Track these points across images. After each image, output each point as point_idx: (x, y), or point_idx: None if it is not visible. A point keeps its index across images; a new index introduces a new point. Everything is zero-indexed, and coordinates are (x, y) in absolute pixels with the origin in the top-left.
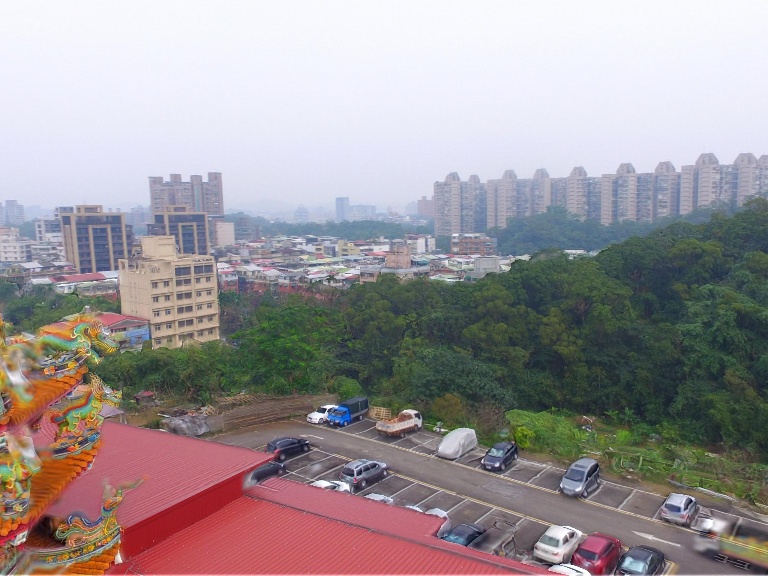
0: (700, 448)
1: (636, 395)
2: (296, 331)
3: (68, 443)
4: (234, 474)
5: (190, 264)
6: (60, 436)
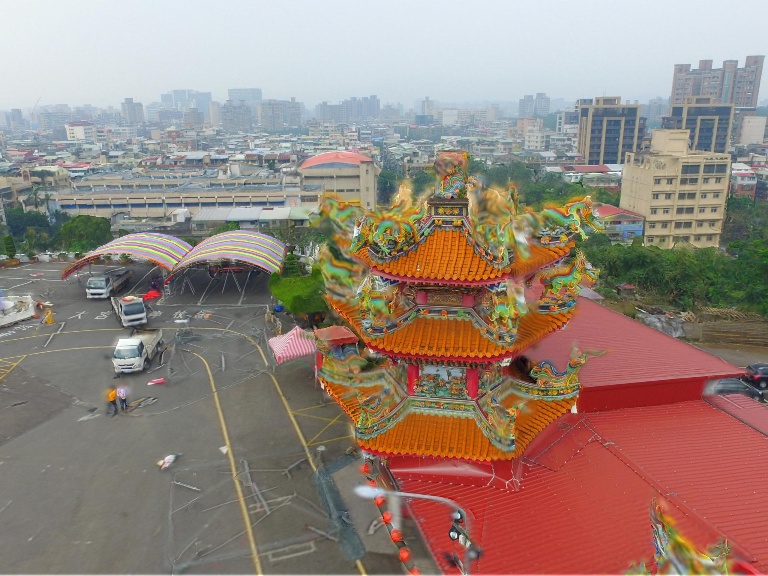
0: None
1: None
2: None
3: (550, 303)
4: (696, 376)
5: (700, 162)
6: (545, 296)
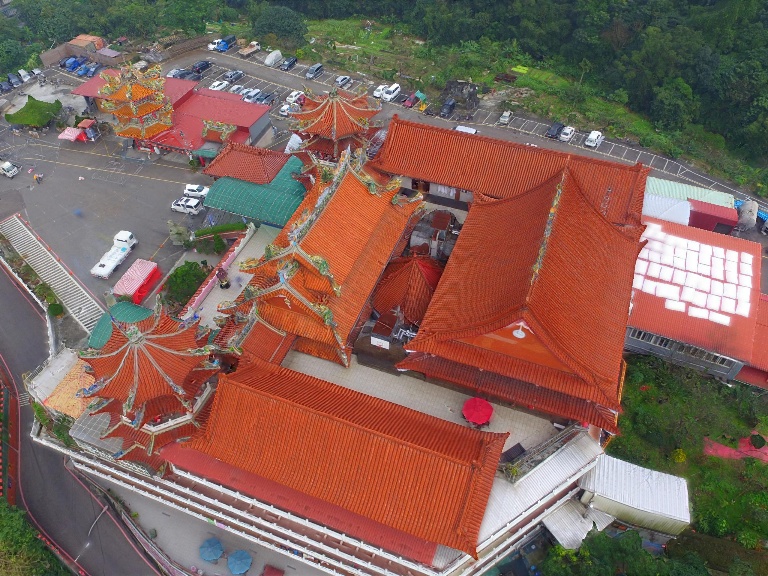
0: (420, 38)
1: (399, 5)
2: (193, 5)
3: (159, 89)
4: (191, 89)
5: None
6: None
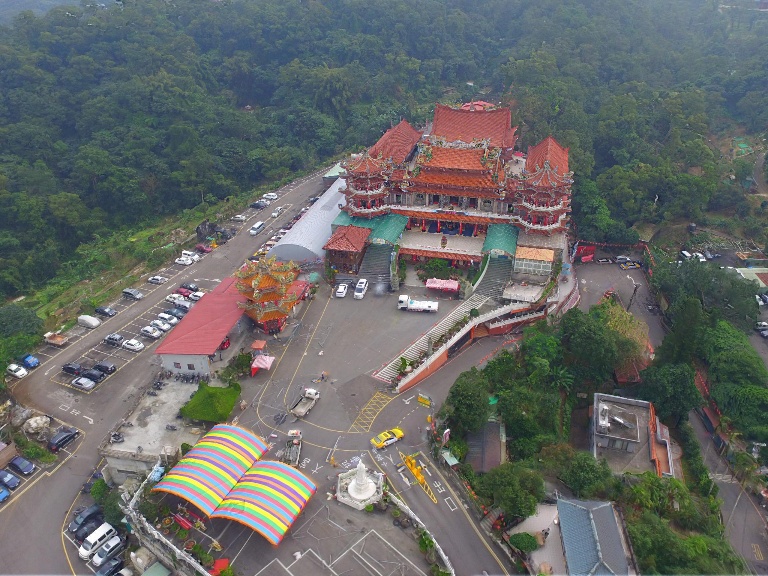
0: (10, 300)
1: None
2: None
3: None
4: None
5: None
6: None
